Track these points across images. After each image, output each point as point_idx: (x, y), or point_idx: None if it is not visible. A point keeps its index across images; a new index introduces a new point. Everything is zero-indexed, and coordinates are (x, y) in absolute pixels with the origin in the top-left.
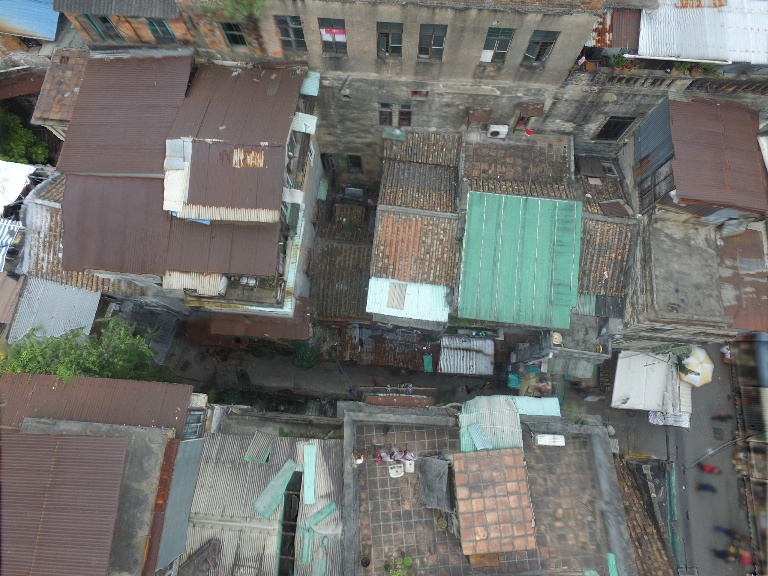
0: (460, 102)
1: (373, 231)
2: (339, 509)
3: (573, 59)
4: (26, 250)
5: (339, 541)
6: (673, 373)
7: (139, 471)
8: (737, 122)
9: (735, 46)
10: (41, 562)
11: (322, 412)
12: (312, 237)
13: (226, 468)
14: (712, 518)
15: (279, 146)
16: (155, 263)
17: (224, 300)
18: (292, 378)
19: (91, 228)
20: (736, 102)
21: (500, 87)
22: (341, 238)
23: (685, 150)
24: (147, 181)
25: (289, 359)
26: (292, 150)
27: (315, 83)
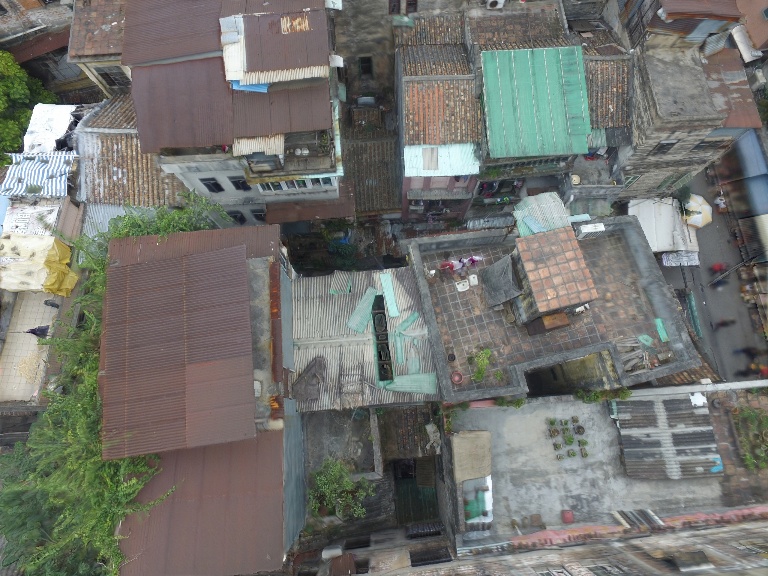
0: None
1: (391, 128)
2: (421, 316)
3: None
4: (82, 178)
5: (427, 340)
6: None
7: (250, 292)
8: None
9: None
10: (193, 350)
11: None
12: None
13: (316, 302)
14: (731, 345)
15: (320, 9)
16: (224, 134)
17: (283, 172)
18: None
19: (161, 111)
20: None
21: None
22: (364, 137)
23: None
24: (206, 61)
25: None
26: None
27: None
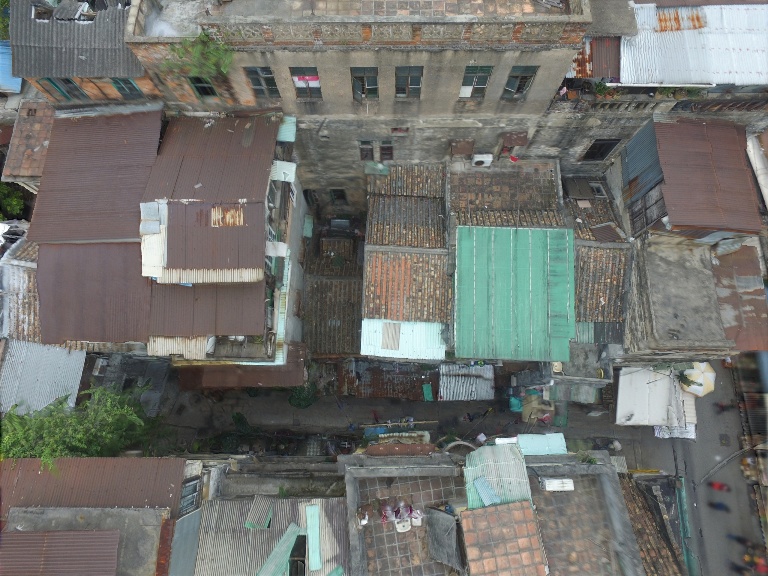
0: (442, 135)
1: (362, 263)
2: (347, 573)
3: (554, 90)
4: (5, 313)
5: None
6: (675, 385)
7: (135, 557)
8: (724, 140)
9: (718, 68)
10: None
11: (323, 448)
12: (300, 276)
13: (227, 538)
14: (725, 527)
15: (258, 202)
16: (138, 330)
17: (213, 358)
18: (291, 414)
19: (68, 298)
20: (722, 119)
21: (481, 119)
22: (330, 273)
23: (674, 174)
24: (123, 246)
25: (286, 395)
26: (273, 198)
27: (291, 128)
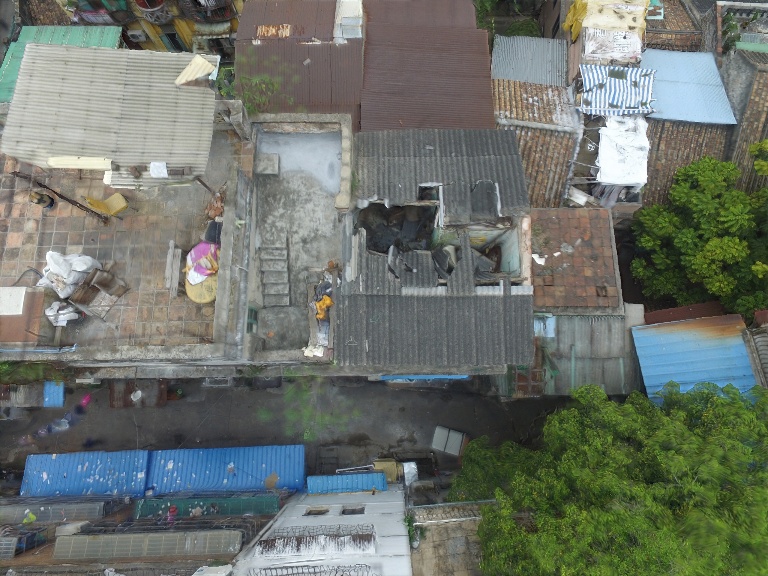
0: None
1: None
2: None
3: None
4: None
5: None
6: None
7: None
8: None
9: None
10: None
11: None
12: None
13: None
14: None
15: (240, 40)
16: None
17: None
18: None
19: None
20: None
21: None
22: None
23: None
24: None
25: None
26: None
27: None
